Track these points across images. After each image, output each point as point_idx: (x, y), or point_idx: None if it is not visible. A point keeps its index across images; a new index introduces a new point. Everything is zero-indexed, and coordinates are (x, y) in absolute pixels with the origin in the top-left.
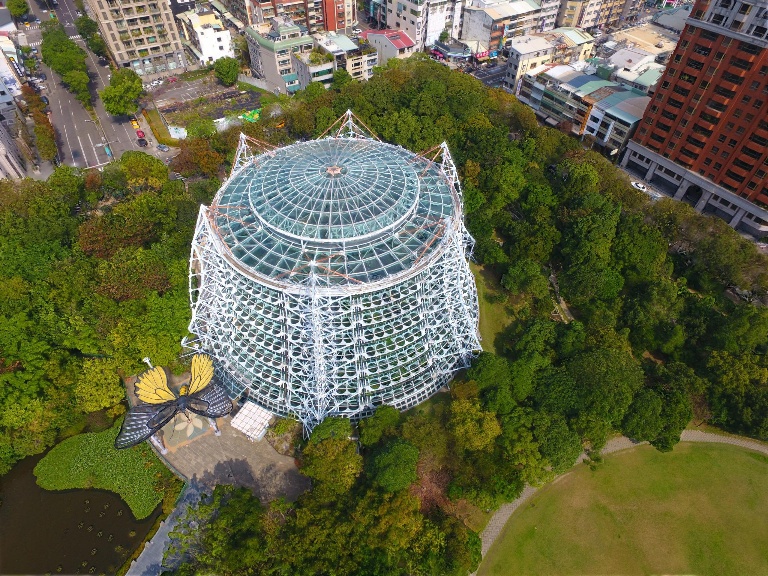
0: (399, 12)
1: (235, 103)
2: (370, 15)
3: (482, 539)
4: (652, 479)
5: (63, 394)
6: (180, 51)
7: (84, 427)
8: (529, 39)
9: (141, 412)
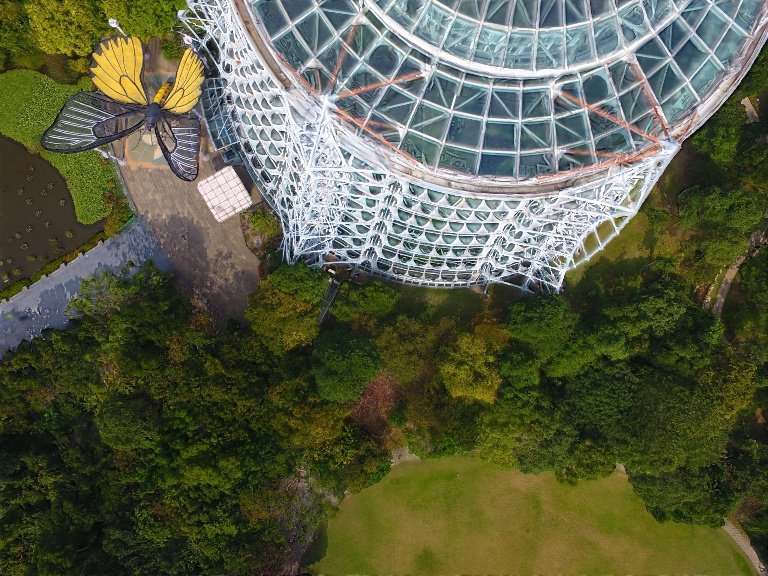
0: None
1: None
2: None
3: (400, 452)
4: (612, 510)
5: (9, 4)
6: None
7: (43, 64)
8: None
9: (90, 105)
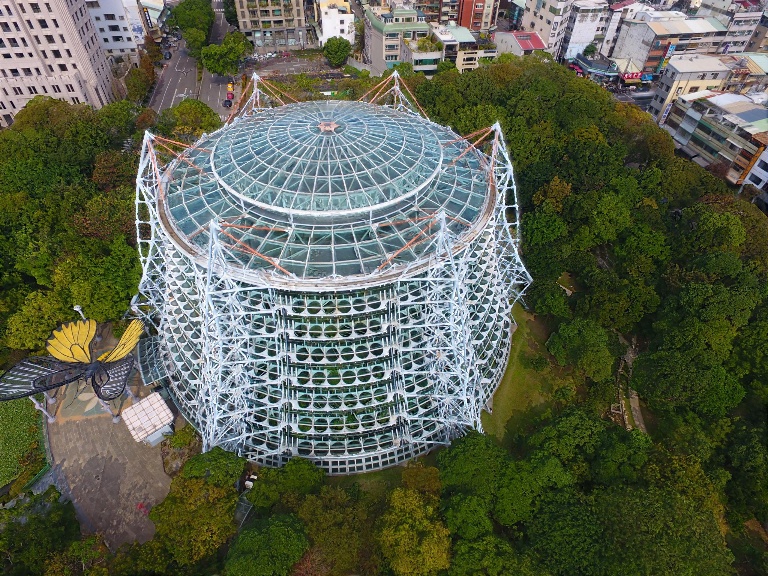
0: (537, 10)
1: (333, 84)
2: (513, 22)
3: None
4: None
5: None
6: (302, 28)
7: (4, 363)
8: (696, 57)
9: None
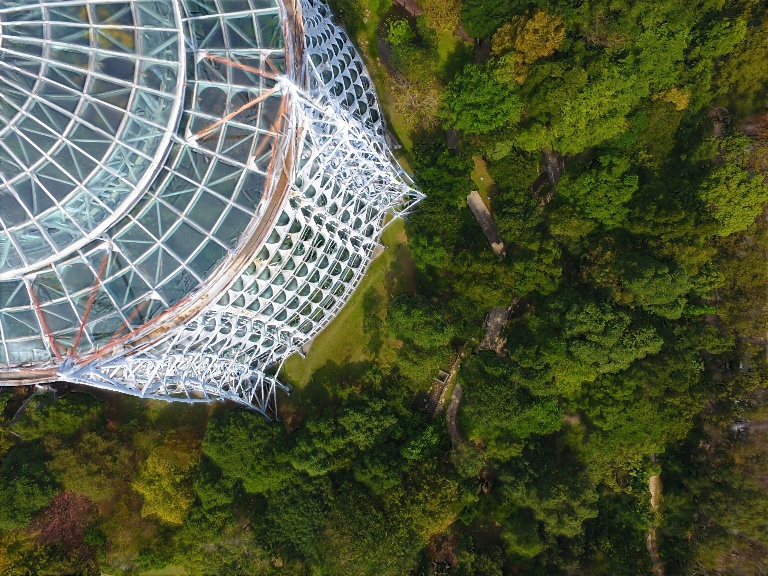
0: None
1: None
2: None
3: None
4: None
5: None
6: None
7: None
8: None
9: None
